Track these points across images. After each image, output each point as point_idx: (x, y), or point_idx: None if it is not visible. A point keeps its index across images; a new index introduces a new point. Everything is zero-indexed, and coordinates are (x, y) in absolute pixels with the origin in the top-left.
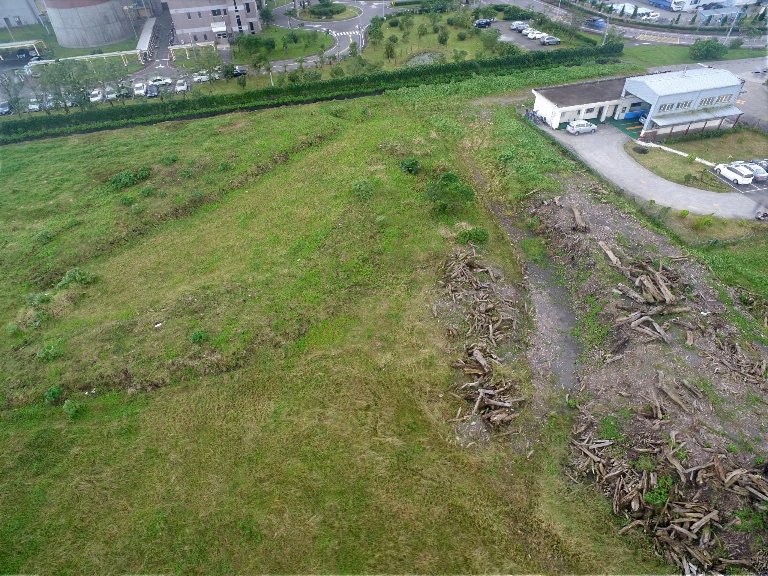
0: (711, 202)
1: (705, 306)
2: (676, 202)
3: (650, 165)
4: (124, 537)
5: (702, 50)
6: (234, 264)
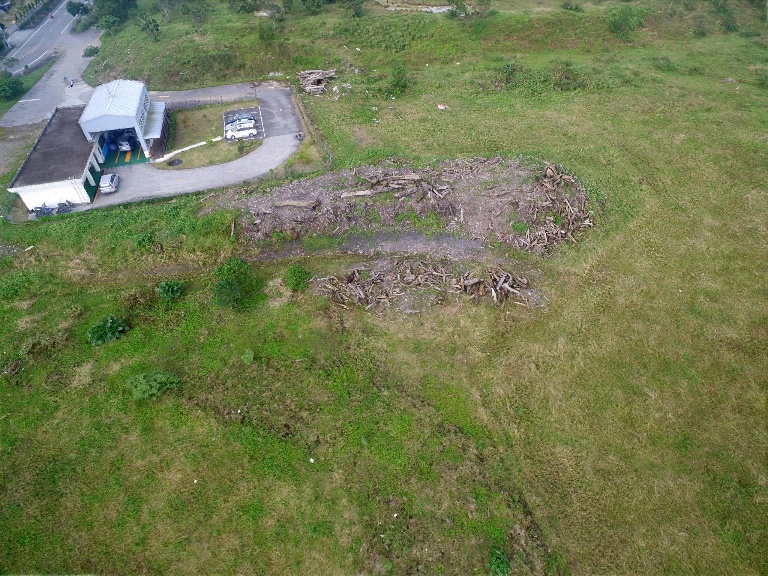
0: (273, 151)
1: (405, 174)
2: (268, 164)
3: (204, 163)
4: (760, 568)
5: (7, 89)
6: (308, 574)
